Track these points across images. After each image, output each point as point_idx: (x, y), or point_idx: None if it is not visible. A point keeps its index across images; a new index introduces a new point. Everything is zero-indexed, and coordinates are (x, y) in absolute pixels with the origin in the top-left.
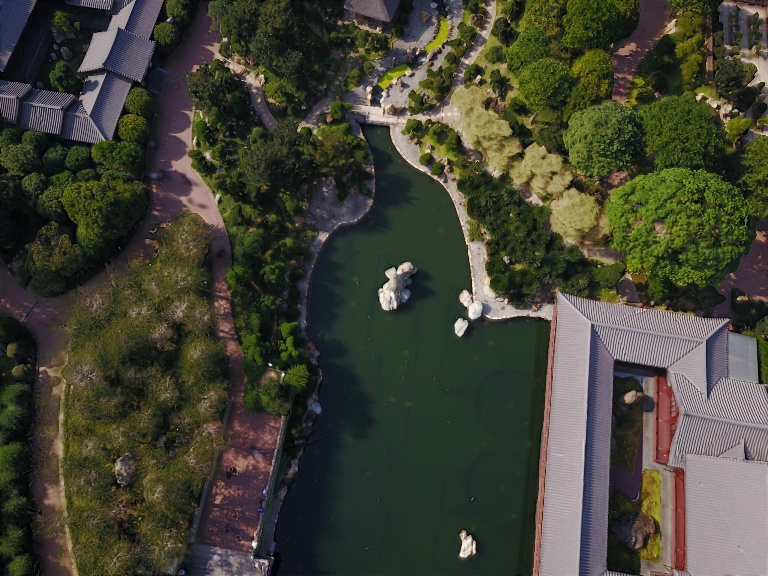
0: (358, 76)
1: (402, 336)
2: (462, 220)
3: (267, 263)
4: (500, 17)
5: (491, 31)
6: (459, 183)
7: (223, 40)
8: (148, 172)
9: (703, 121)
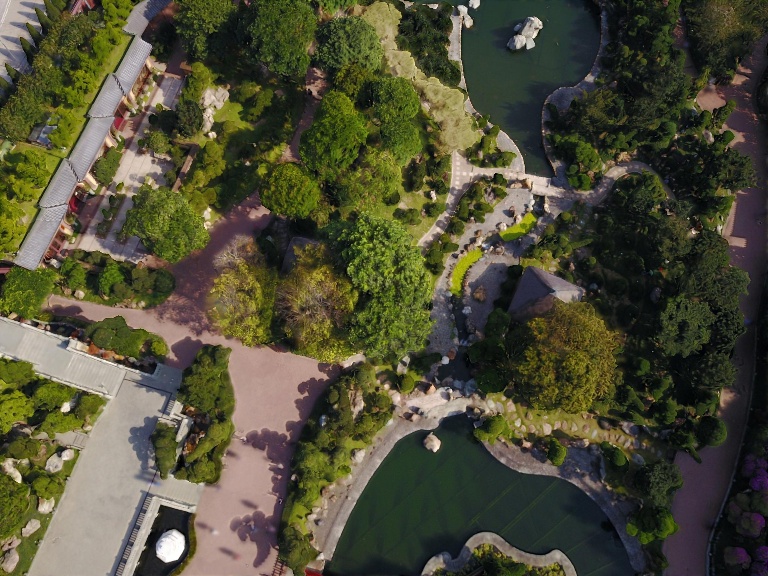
0: None
1: (521, 6)
2: (463, 80)
3: (640, 50)
4: None
5: None
6: (467, 96)
7: None
8: (765, 132)
9: (270, 8)
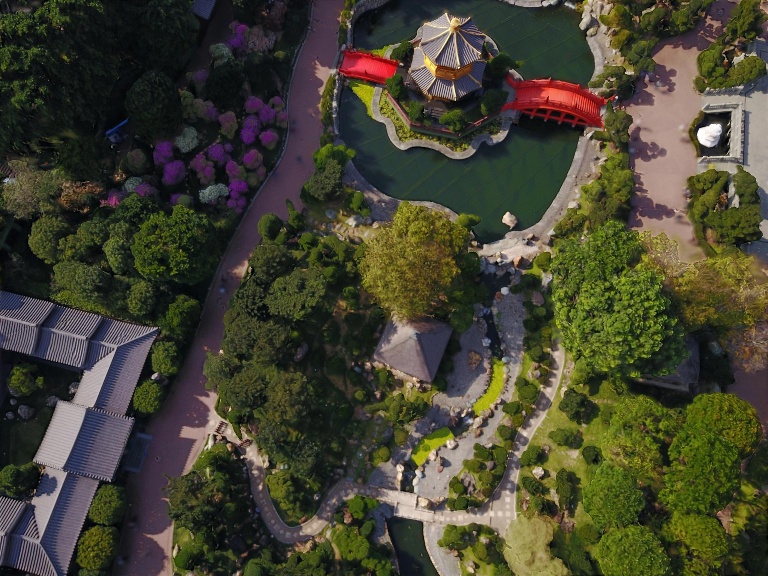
0: (387, 457)
1: None
2: None
3: None
4: (571, 387)
5: (559, 405)
6: None
7: (220, 400)
8: None
9: None
